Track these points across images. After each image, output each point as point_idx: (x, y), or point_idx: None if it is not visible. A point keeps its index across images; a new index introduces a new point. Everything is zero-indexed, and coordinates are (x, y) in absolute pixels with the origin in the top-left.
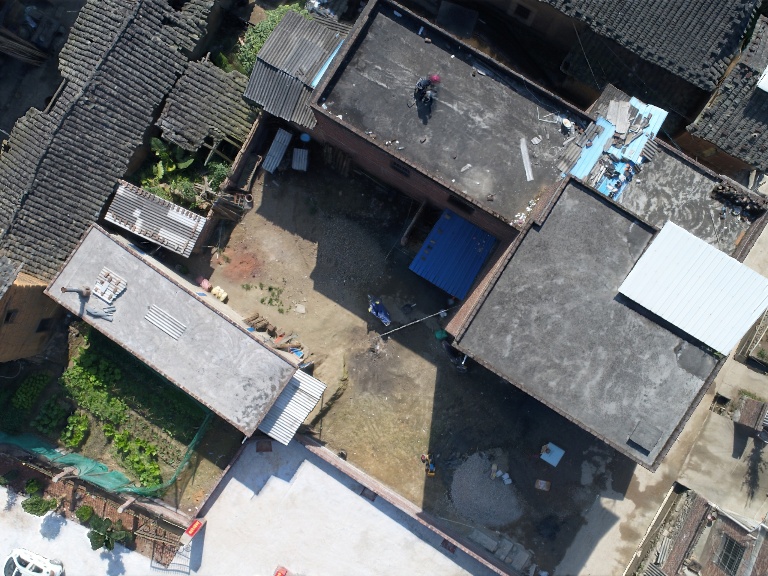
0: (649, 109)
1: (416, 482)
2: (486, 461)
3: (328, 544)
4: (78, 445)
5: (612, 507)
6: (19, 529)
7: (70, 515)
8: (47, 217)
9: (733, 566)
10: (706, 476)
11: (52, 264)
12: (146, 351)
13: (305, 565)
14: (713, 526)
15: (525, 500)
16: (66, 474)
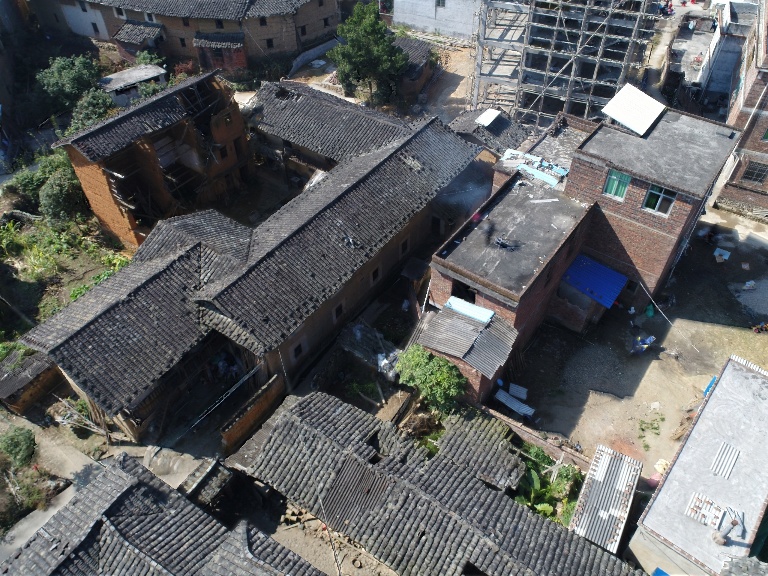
0: (507, 154)
1: None
2: None
3: None
4: None
5: (744, 235)
6: None
7: None
8: None
9: (763, 168)
10: None
11: None
12: (763, 482)
13: None
14: None
15: (762, 276)
16: None
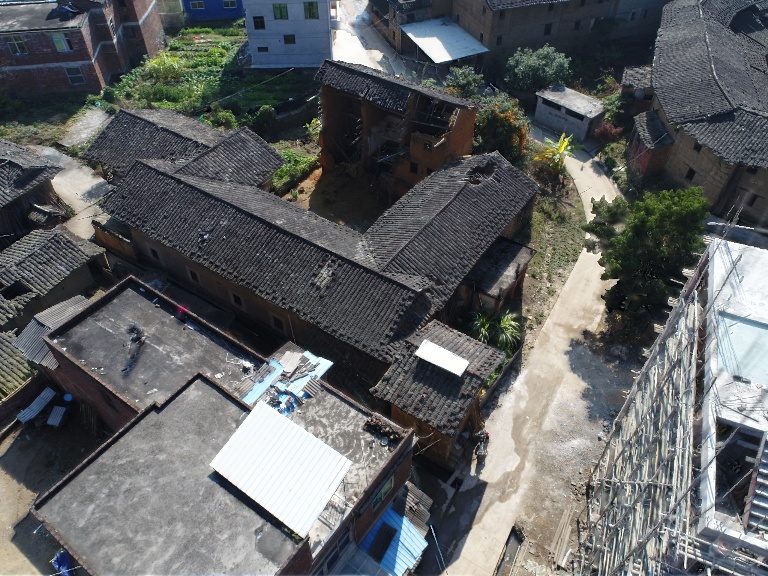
0: (318, 360)
1: None
2: None
3: None
4: None
5: None
6: None
7: None
8: None
9: None
10: None
11: None
12: None
13: None
14: None
15: None
16: None
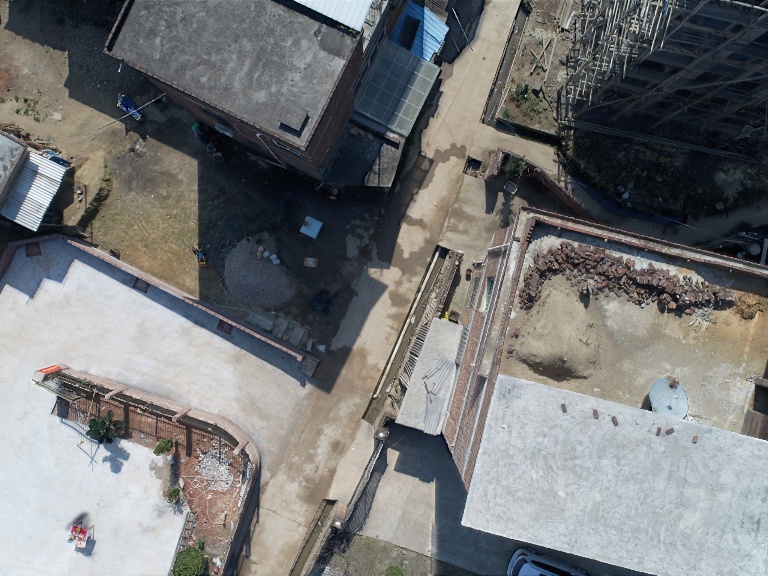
0: None
1: (190, 274)
2: (254, 245)
3: (107, 338)
4: None
5: (380, 276)
6: None
7: None
8: None
9: None
10: (463, 235)
11: None
12: None
13: (87, 361)
14: (471, 279)
15: (296, 279)
16: None
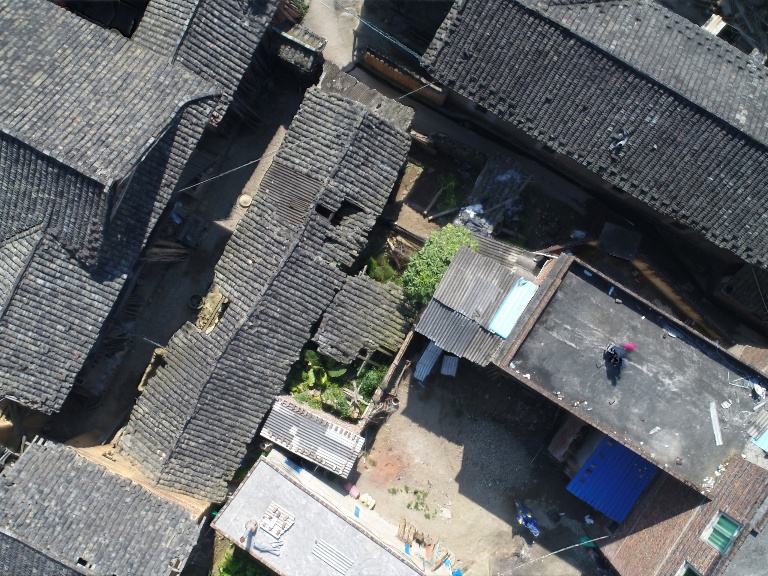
0: None
1: None
2: None
3: None
4: None
5: None
6: None
7: None
8: (207, 439)
9: None
10: None
11: (209, 483)
12: None
13: None
14: None
15: None
16: None
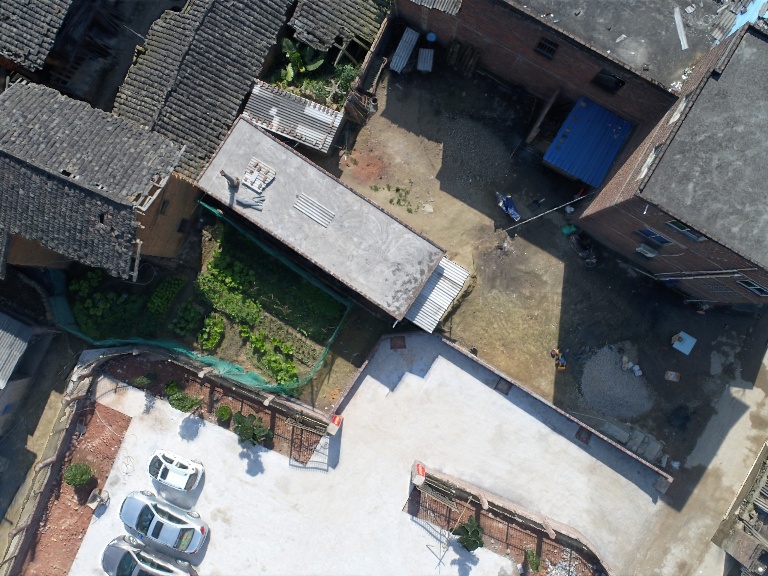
0: None
1: (546, 377)
2: (616, 354)
3: (464, 438)
4: (214, 347)
5: (742, 396)
6: (158, 432)
7: (208, 417)
8: (188, 115)
9: None
10: None
11: (192, 163)
12: (296, 239)
13: (441, 459)
14: None
15: (655, 392)
16: (209, 371)
